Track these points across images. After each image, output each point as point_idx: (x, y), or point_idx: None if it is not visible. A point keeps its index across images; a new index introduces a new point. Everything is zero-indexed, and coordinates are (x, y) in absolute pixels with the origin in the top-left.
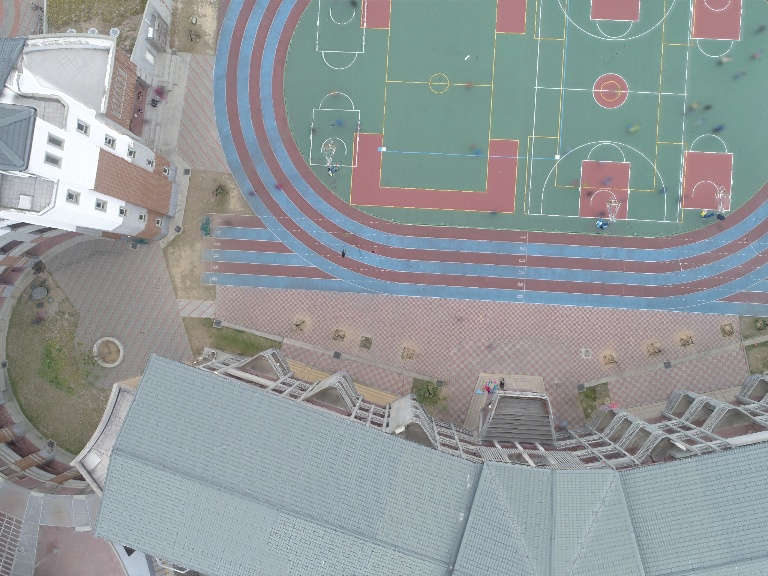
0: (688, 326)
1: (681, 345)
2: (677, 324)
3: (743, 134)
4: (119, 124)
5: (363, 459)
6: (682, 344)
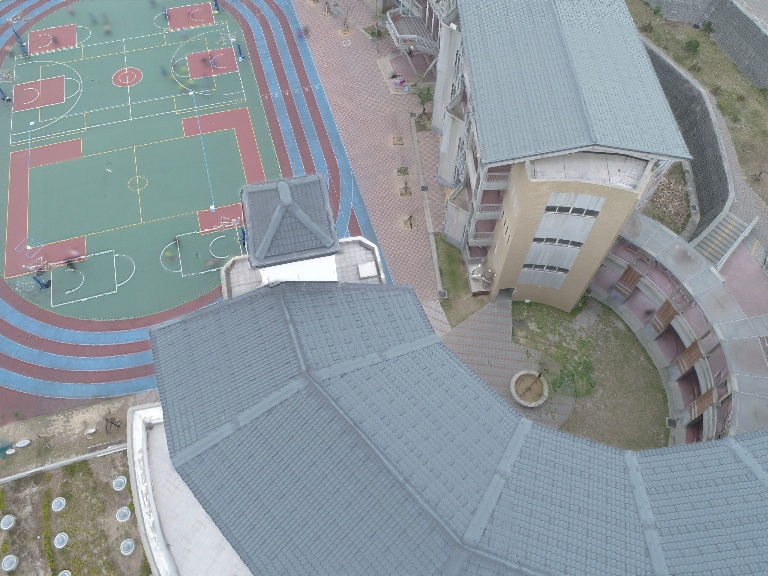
0: (303, 2)
1: (318, 3)
2: (304, 7)
3: (150, 8)
4: None
5: (486, 3)
6: (317, 2)
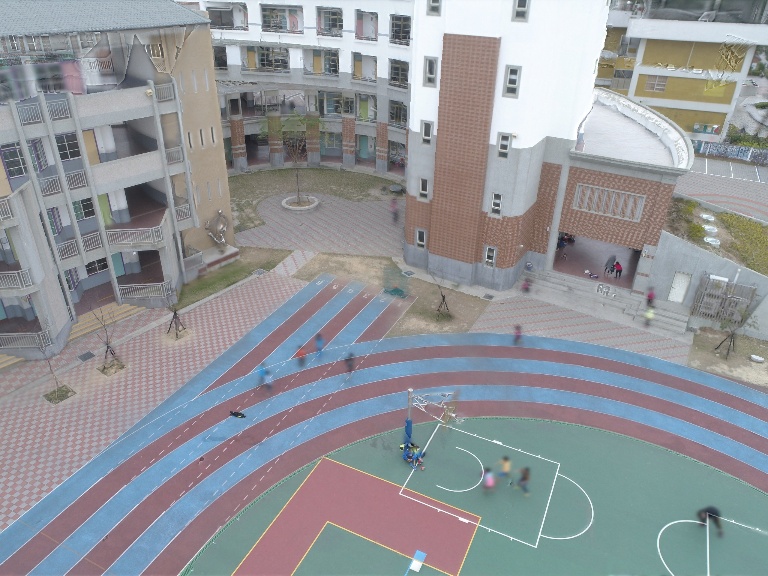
0: None
1: None
2: None
3: None
4: (564, 206)
5: None
6: None
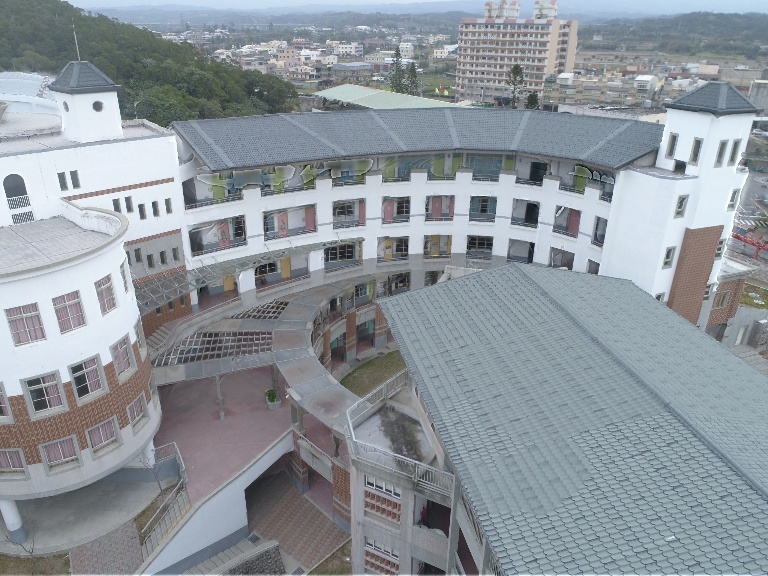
0: None
1: None
2: None
3: None
4: None
5: None
6: None
